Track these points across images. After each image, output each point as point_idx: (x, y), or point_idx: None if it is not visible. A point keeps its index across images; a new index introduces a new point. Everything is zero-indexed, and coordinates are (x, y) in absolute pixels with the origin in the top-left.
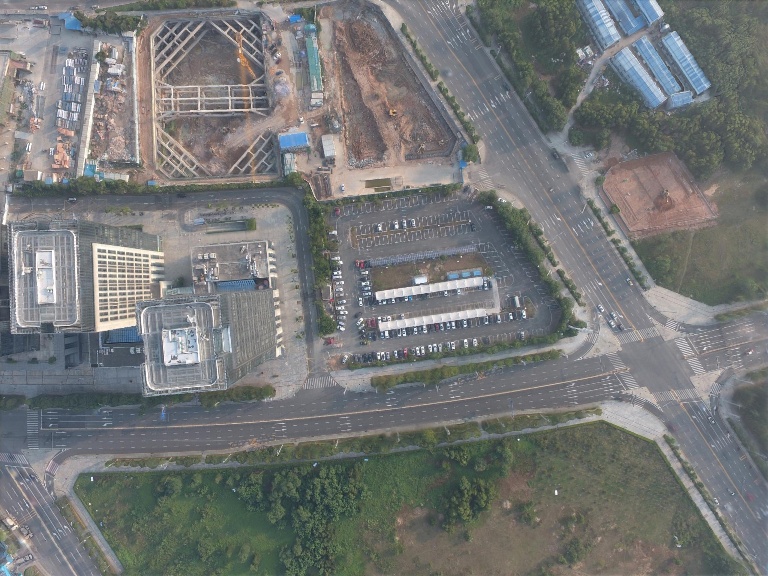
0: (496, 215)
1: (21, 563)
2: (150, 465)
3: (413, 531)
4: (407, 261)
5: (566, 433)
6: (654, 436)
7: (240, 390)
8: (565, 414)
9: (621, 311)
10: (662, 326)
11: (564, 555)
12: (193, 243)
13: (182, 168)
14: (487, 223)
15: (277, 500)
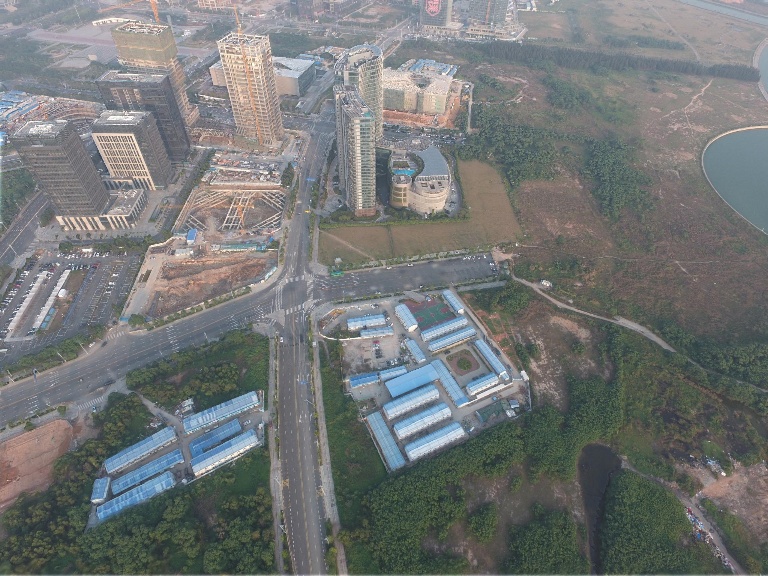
0: None
1: None
2: None
3: None
4: None
5: None
6: None
7: None
8: None
9: None
10: None
11: None
12: (155, 200)
13: None
14: None
15: None
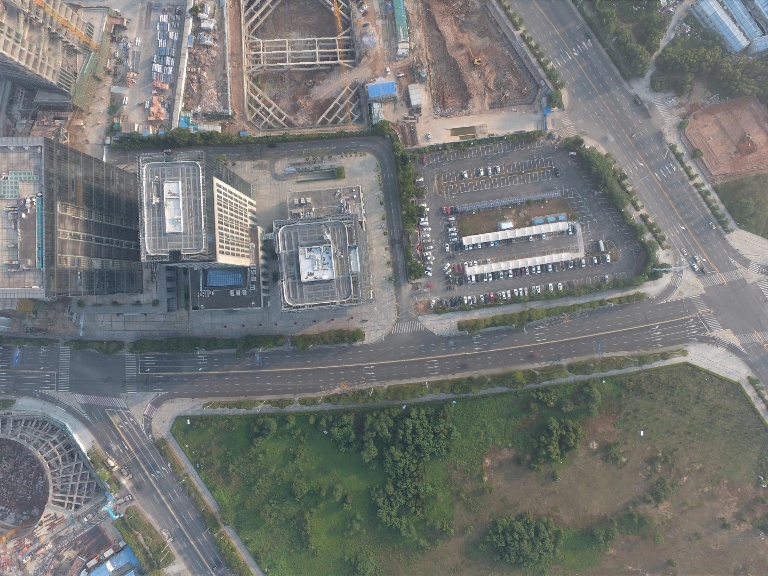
0: (579, 161)
1: (121, 503)
2: (247, 406)
3: (501, 471)
4: (493, 207)
5: (651, 375)
6: (738, 378)
7: (333, 333)
8: (650, 356)
9: (704, 254)
10: (745, 269)
11: (651, 494)
12: (284, 192)
13: (270, 121)
14: (570, 169)
15: (370, 440)
